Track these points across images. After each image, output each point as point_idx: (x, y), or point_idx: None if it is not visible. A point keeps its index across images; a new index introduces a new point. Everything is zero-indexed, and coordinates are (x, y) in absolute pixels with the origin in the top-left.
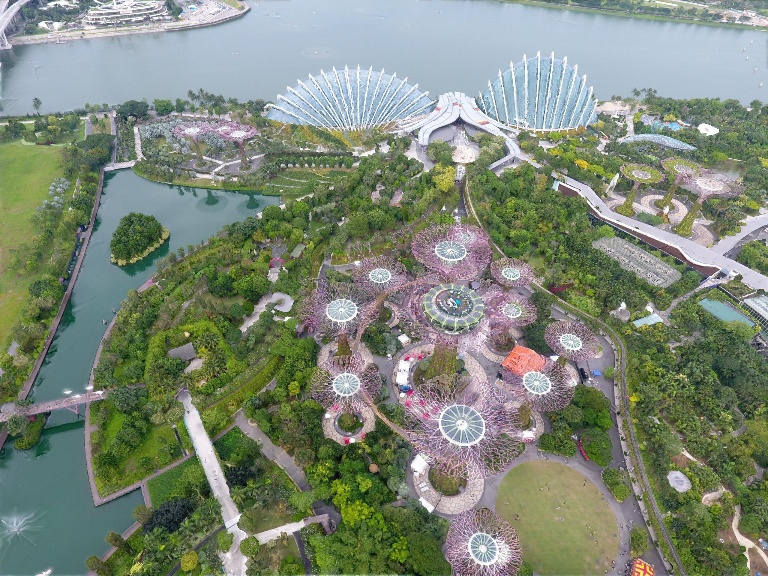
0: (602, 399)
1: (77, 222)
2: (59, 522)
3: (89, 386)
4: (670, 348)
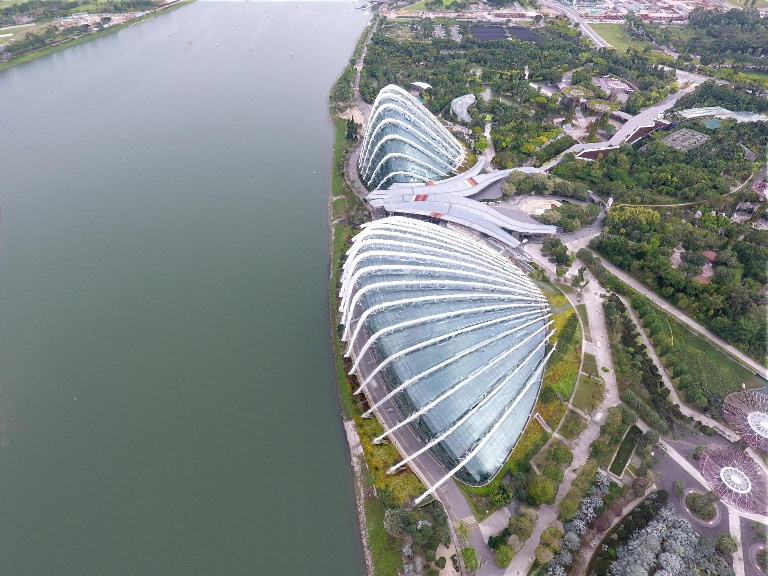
0: None
1: None
2: None
3: None
4: None
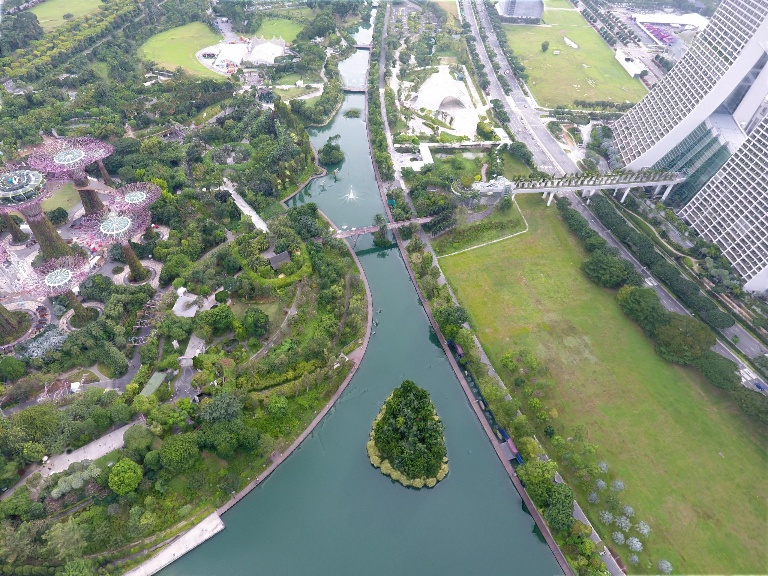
0: None
1: None
2: (333, 203)
3: (357, 258)
4: None
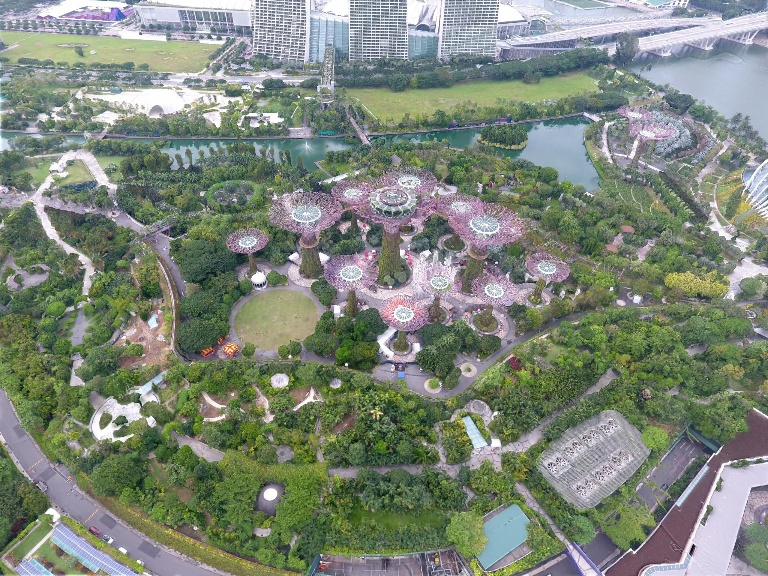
0: (361, 352)
1: (511, 115)
2: (310, 158)
3: None
4: (436, 447)
